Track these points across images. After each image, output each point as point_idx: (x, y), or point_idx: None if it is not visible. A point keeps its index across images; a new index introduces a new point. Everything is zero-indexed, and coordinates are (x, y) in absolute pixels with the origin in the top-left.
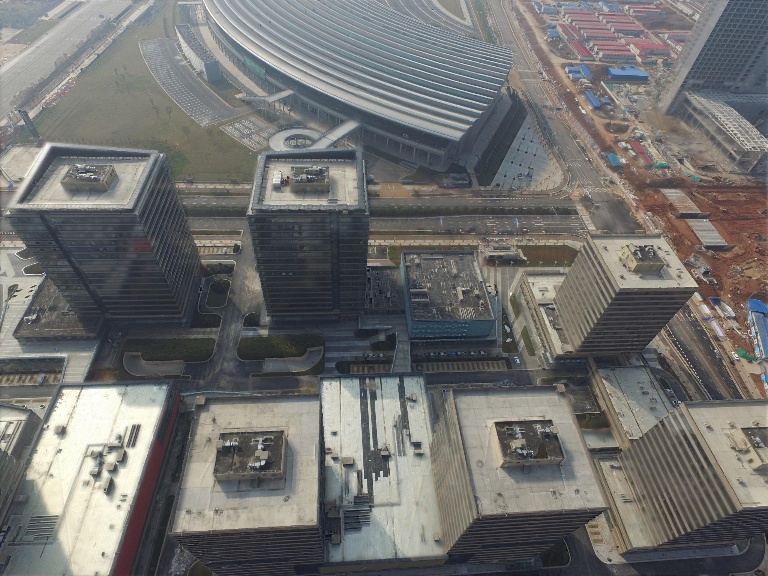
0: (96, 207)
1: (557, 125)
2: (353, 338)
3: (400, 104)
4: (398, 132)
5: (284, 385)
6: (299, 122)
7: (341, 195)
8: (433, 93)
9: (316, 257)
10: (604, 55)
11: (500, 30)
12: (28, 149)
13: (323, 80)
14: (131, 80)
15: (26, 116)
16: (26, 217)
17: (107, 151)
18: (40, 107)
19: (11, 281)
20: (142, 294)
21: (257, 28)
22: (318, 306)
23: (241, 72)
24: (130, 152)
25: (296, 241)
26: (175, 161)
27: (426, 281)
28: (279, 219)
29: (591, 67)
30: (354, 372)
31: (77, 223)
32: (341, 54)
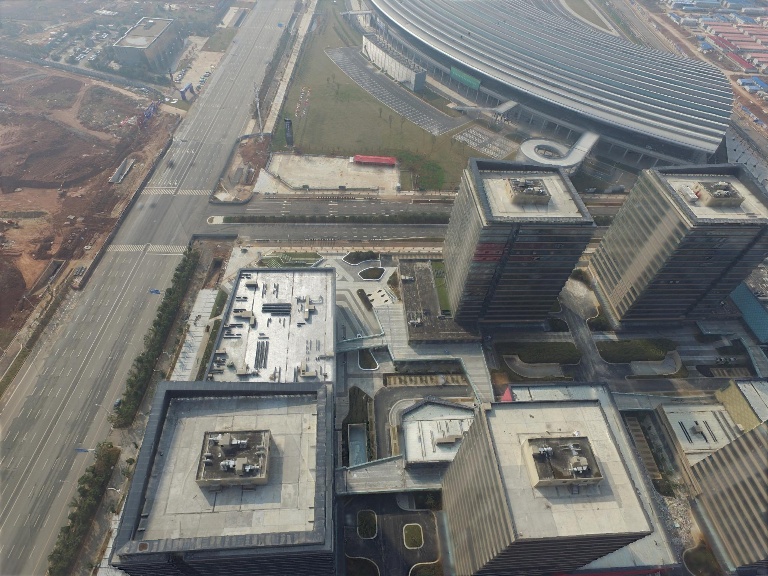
0: (563, 220)
1: (757, 137)
2: (697, 343)
3: (642, 117)
4: (639, 143)
5: (661, 387)
6: (522, 132)
7: (753, 209)
8: (671, 106)
9: (713, 267)
10: (767, 67)
11: (649, 41)
12: (289, 157)
13: (555, 92)
14: (342, 89)
15: (290, 125)
16: (501, 229)
17: (521, 166)
18: (273, 115)
19: (355, 286)
20: (530, 300)
21: (460, 40)
22: (671, 312)
23: (438, 82)
24: (540, 167)
25: (710, 252)
26: (432, 170)
27: (764, 289)
28: (715, 232)
29: (761, 79)
30: (717, 375)
31: (538, 234)
32: (558, 66)
